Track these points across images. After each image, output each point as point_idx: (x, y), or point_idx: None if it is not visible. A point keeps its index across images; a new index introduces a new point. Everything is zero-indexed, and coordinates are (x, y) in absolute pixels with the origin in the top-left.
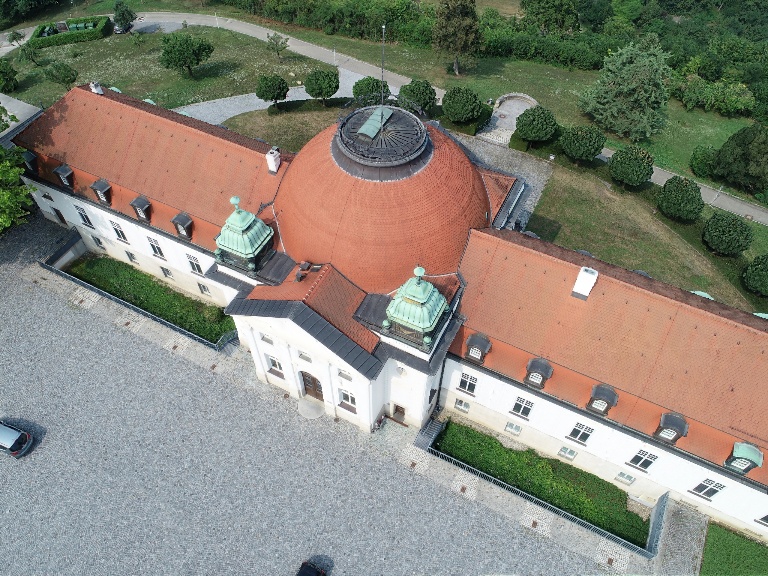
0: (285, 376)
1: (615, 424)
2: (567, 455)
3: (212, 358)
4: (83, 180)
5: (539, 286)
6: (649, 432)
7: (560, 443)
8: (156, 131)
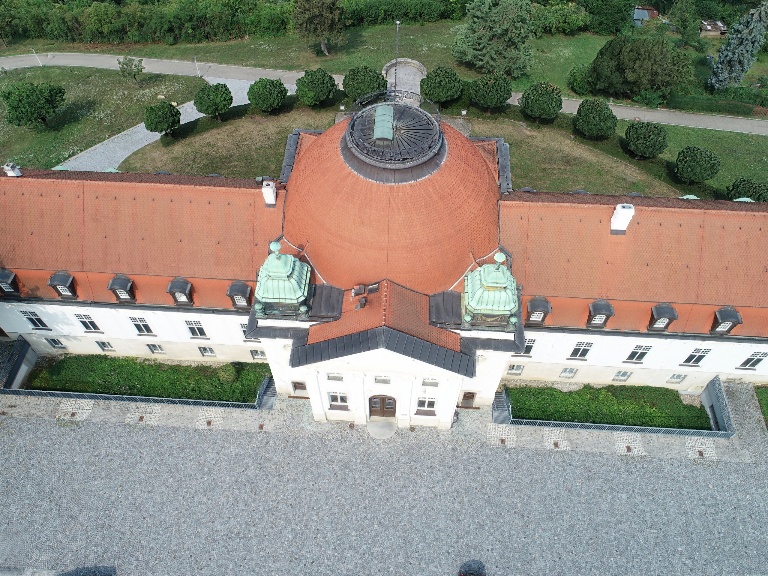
0: (350, 407)
1: (676, 335)
2: (621, 378)
3: (255, 418)
4: (31, 280)
5: (579, 235)
6: (706, 331)
7: (616, 369)
8: (112, 199)
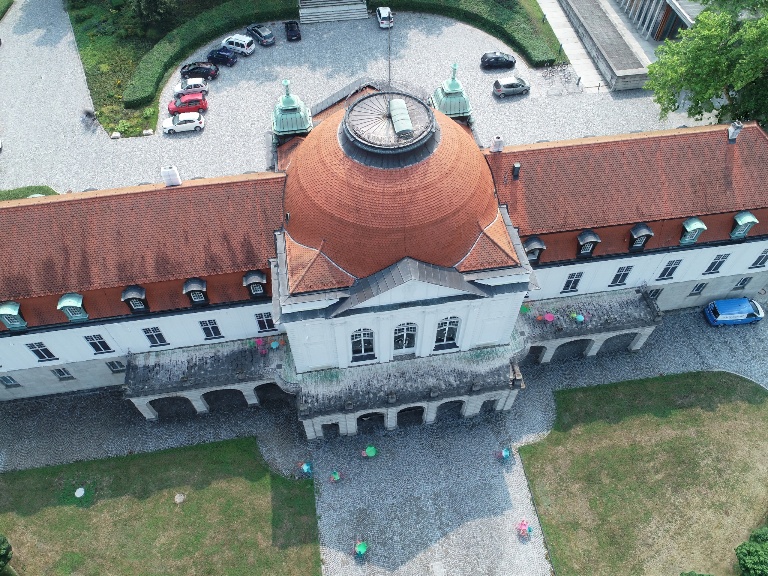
0: None
1: None
2: None
3: None
4: None
5: None
6: None
7: None
8: None
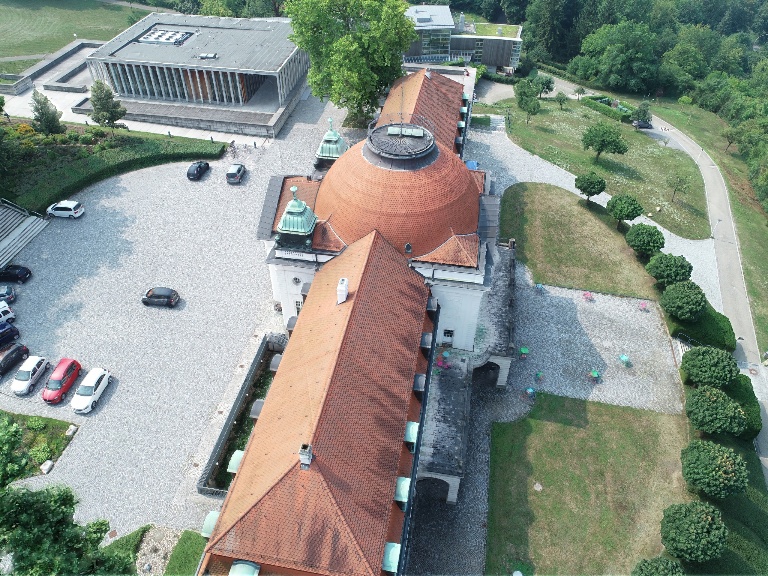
0: None
1: None
2: None
3: None
4: None
5: None
6: None
7: None
8: None
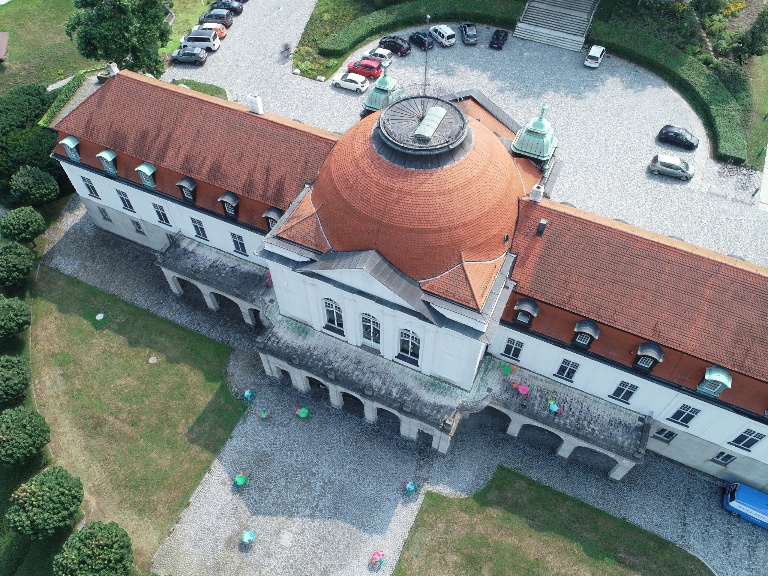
0: None
1: None
2: None
3: None
4: None
5: None
6: None
7: None
8: None
